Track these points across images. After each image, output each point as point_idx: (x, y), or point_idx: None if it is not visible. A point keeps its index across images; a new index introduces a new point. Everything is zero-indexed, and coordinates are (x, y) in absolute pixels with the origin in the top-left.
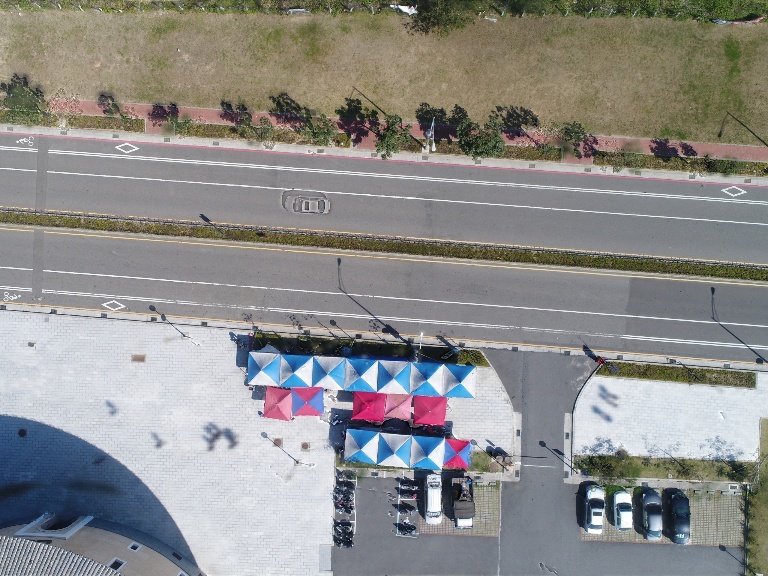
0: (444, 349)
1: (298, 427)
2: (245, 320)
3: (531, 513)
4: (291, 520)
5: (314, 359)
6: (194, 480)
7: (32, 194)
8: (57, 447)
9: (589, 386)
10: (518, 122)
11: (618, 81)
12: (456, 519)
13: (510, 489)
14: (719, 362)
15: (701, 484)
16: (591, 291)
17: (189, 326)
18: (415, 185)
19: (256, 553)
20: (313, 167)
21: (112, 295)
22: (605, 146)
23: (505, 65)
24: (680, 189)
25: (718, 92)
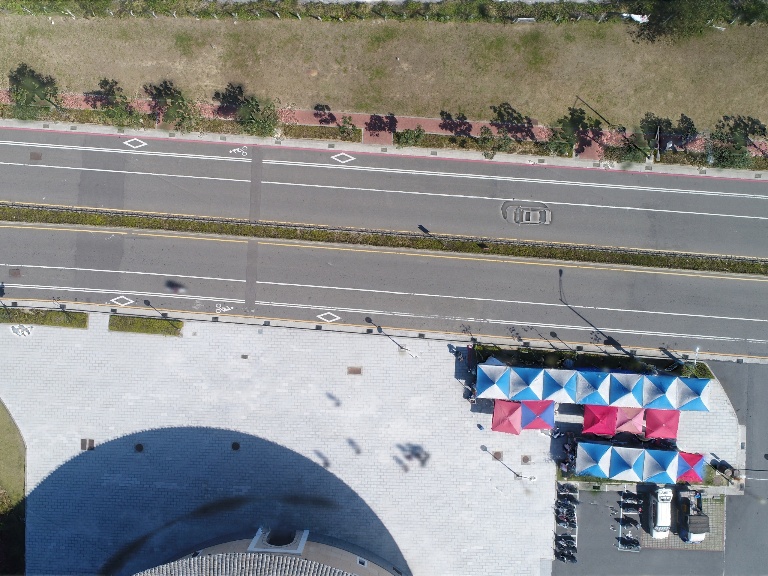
0: (668, 361)
1: (518, 440)
2: (463, 332)
3: (756, 527)
4: (511, 534)
5: (545, 372)
6: (412, 494)
7: (246, 205)
8: (271, 460)
9: None
10: (745, 132)
11: None
12: (687, 534)
13: (735, 503)
14: None
15: None
16: None
17: (406, 338)
18: (638, 195)
19: (475, 568)
20: (534, 177)
21: (327, 307)
22: None
23: (733, 74)
24: None
25: None
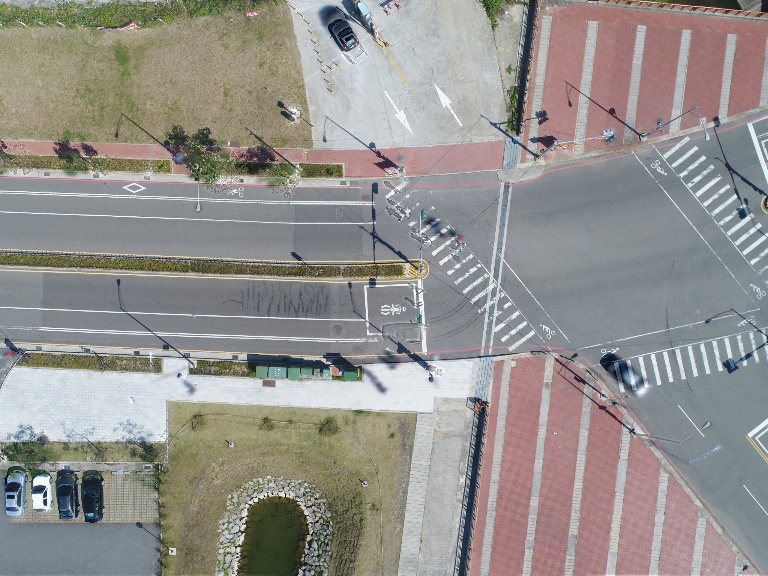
0: None
1: None
2: None
3: None
4: None
5: None
6: None
7: None
8: None
9: (10, 377)
10: None
11: (20, 88)
12: None
13: None
14: (129, 350)
15: (118, 465)
16: (8, 287)
17: None
18: None
19: None
20: None
21: None
22: (14, 150)
23: None
24: (85, 188)
25: (112, 95)
